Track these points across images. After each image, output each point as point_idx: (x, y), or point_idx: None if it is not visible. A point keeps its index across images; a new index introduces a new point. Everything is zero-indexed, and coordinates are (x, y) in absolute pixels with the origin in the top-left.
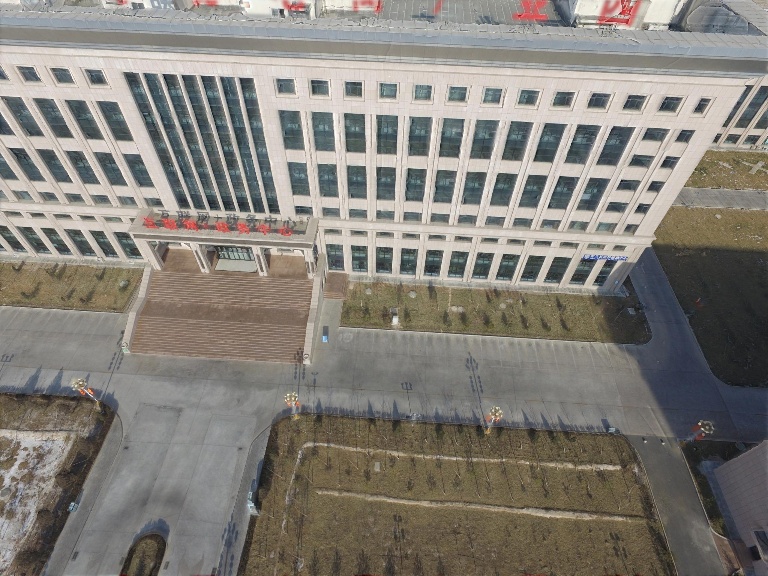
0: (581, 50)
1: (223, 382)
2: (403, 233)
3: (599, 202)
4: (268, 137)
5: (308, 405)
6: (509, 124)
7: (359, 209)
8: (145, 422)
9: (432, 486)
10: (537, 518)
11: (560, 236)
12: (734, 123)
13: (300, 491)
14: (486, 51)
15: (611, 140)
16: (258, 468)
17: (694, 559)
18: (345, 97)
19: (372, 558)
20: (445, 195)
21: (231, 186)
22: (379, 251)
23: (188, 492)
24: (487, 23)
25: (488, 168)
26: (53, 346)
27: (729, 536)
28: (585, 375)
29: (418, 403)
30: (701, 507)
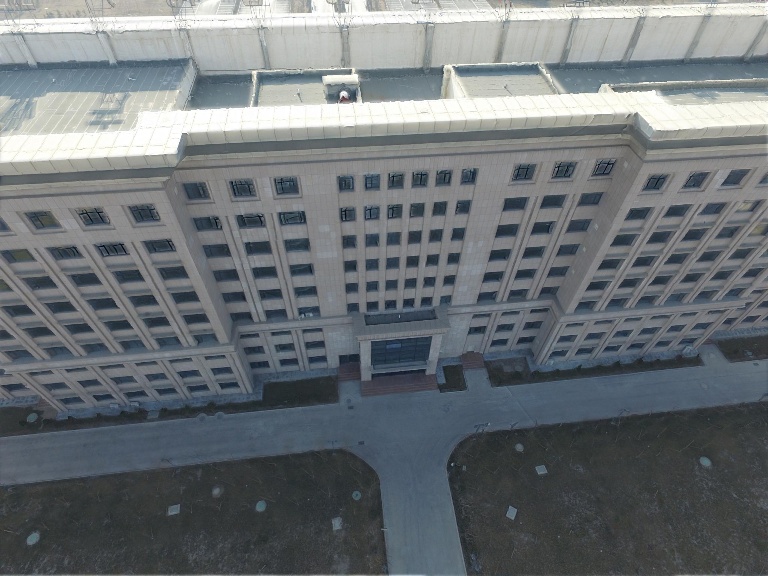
0: None
1: None
2: None
3: None
4: None
5: None
6: None
7: None
8: None
9: None
10: None
11: None
12: None
13: None
14: None
15: None
16: None
17: None
18: None
19: None
20: None
21: None
22: None
23: None
24: (19, 116)
25: None
26: None
27: None
28: None
29: None
30: None
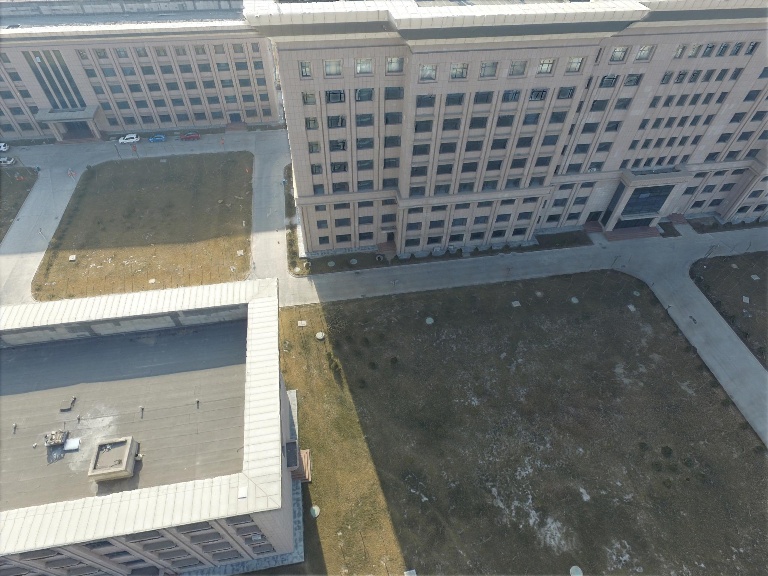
0: None
1: None
2: None
3: None
4: None
5: None
6: None
7: None
8: None
9: None
10: None
11: None
12: None
13: None
14: None
15: None
16: None
17: None
18: None
19: None
20: None
21: None
22: None
23: None
24: None
25: None
26: None
27: None
28: None
29: None
30: None
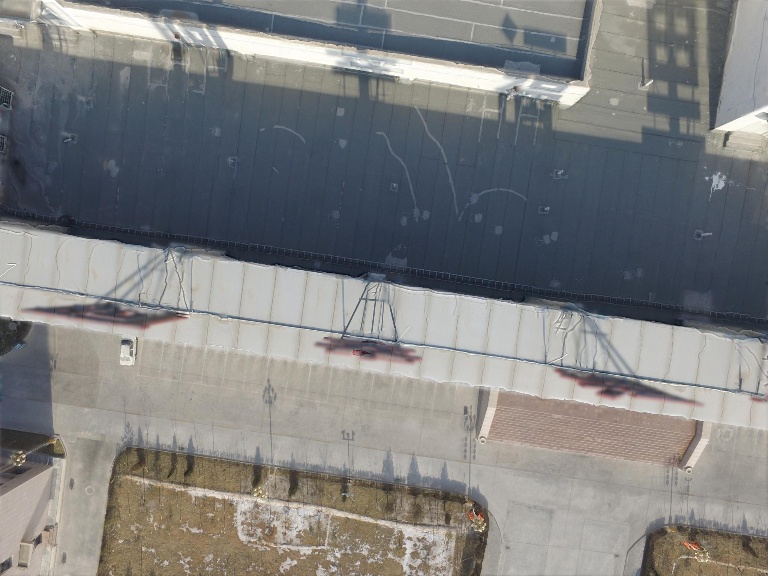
0: None
1: (591, 483)
2: None
3: None
4: None
5: (682, 516)
6: None
7: None
8: (519, 523)
9: None
10: None
11: None
12: None
13: None
14: None
15: None
16: None
17: None
18: None
19: None
20: None
21: None
22: None
23: None
24: None
25: None
26: (393, 423)
27: None
28: None
29: None
30: None
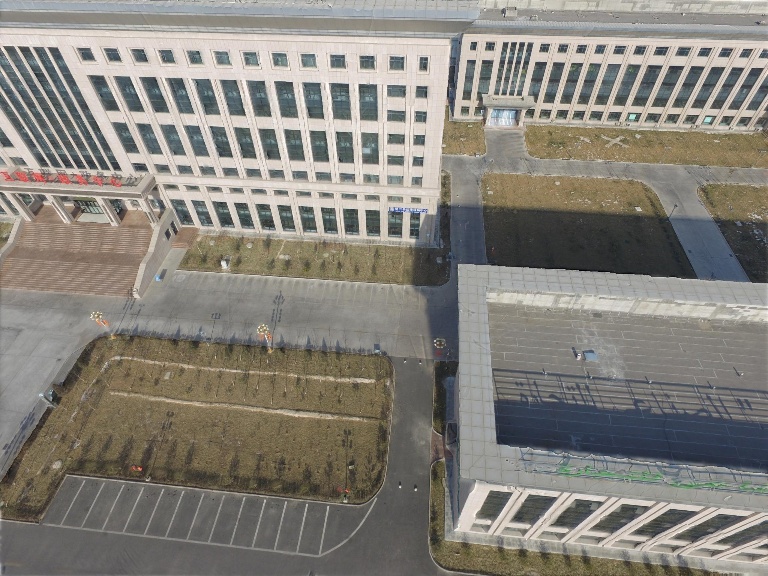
0: (290, 15)
1: (63, 310)
2: (228, 187)
3: (378, 156)
4: (87, 99)
5: (127, 329)
6: (273, 84)
7: (185, 165)
8: None
9: (208, 391)
10: (287, 417)
11: (359, 189)
12: (593, 100)
13: (97, 392)
14: (219, 18)
15: (365, 97)
16: (68, 374)
17: (407, 450)
18: (135, 63)
19: (138, 442)
20: (250, 151)
21: (74, 145)
22: (218, 206)
23: (5, 390)
24: None
25: (273, 125)
26: None
27: (444, 434)
28: (375, 310)
29: (220, 329)
30: (431, 412)
